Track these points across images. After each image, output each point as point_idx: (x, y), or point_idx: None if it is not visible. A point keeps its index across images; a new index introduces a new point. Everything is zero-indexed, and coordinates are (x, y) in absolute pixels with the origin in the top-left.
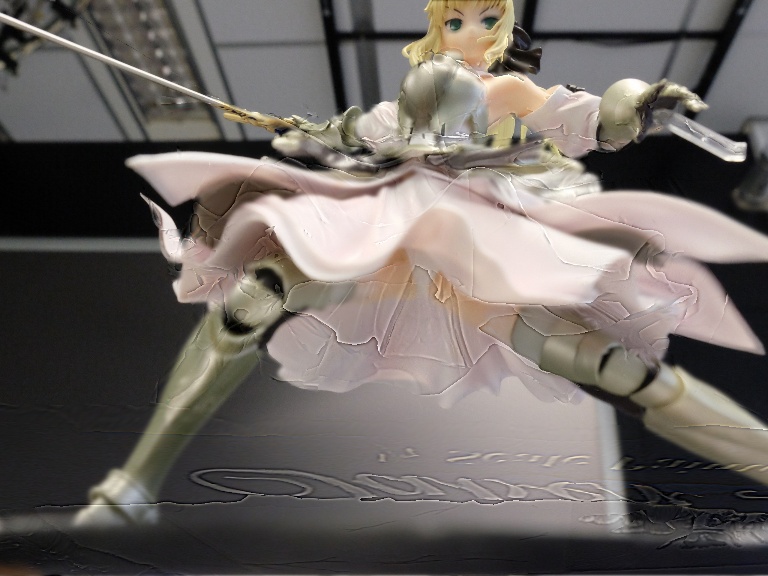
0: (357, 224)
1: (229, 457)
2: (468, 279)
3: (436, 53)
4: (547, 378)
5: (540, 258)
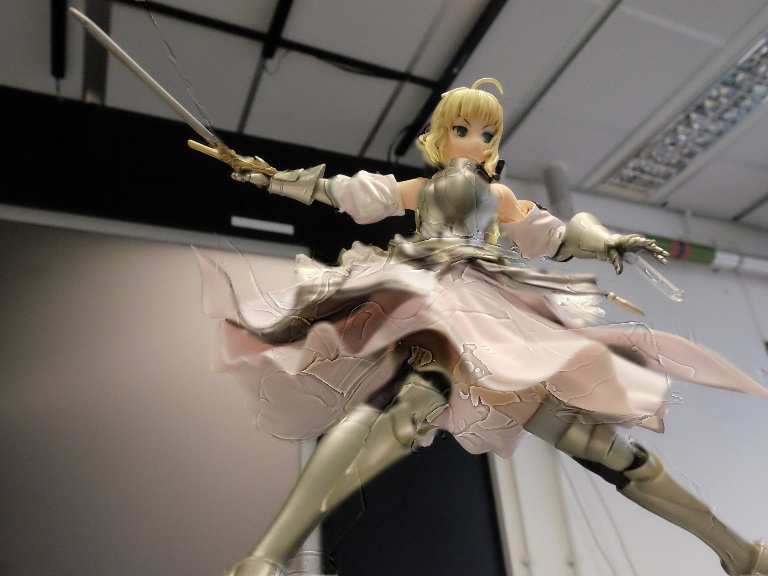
0: (551, 354)
1: None
2: (581, 392)
3: (457, 158)
4: (496, 438)
5: (656, 390)
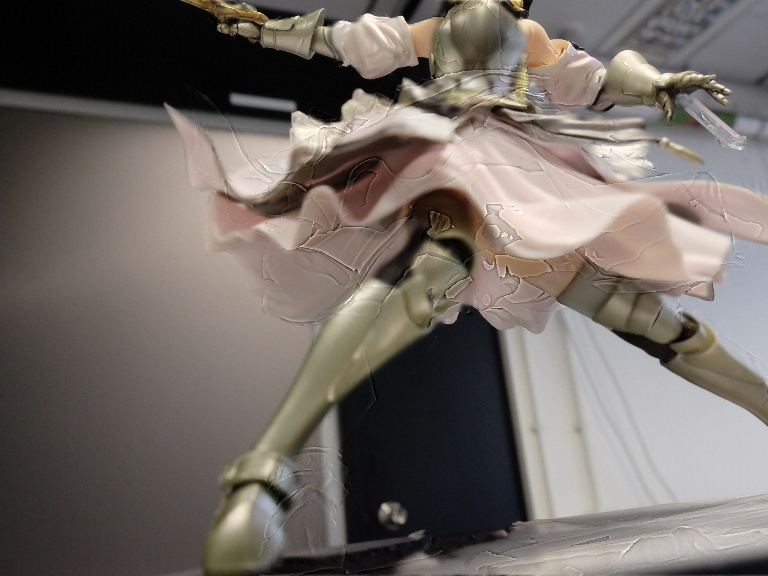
0: (593, 212)
1: None
2: (626, 258)
3: None
4: (525, 313)
5: (717, 251)
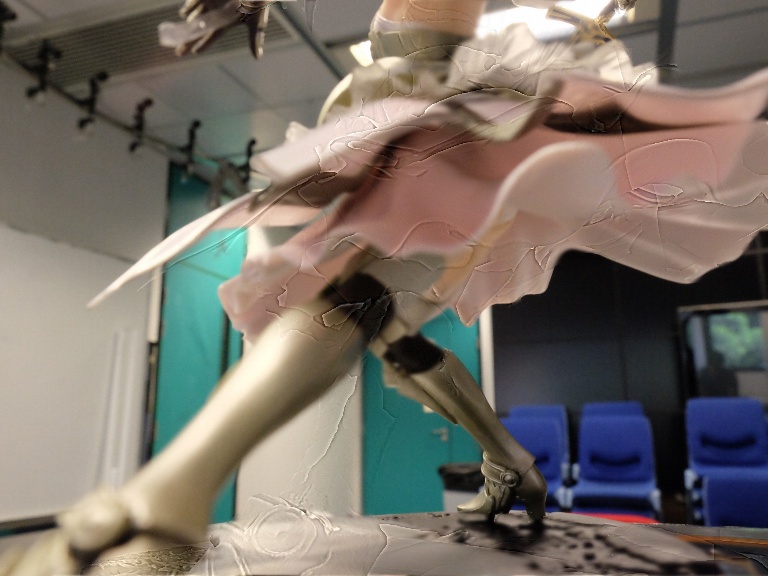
0: None
1: None
2: None
3: None
4: None
5: None
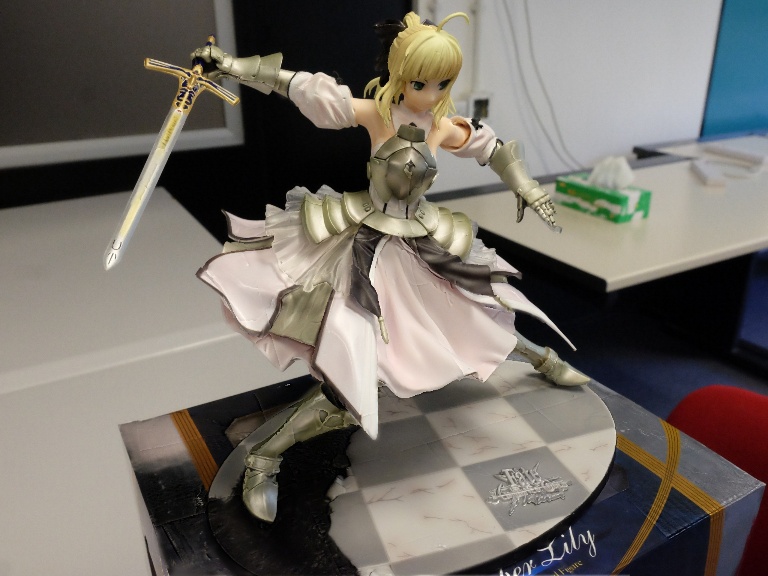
0: (409, 389)
1: None
2: None
3: None
4: None
5: None
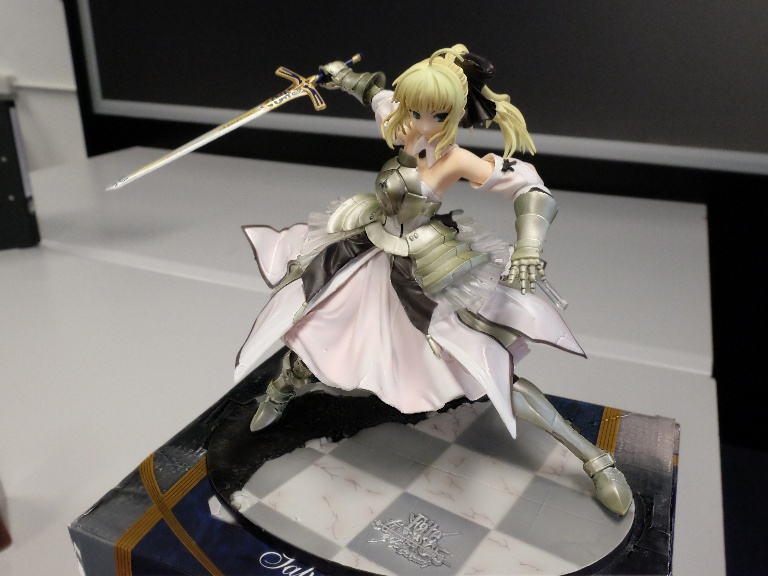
0: None
1: (261, 571)
2: None
3: None
4: None
5: None
